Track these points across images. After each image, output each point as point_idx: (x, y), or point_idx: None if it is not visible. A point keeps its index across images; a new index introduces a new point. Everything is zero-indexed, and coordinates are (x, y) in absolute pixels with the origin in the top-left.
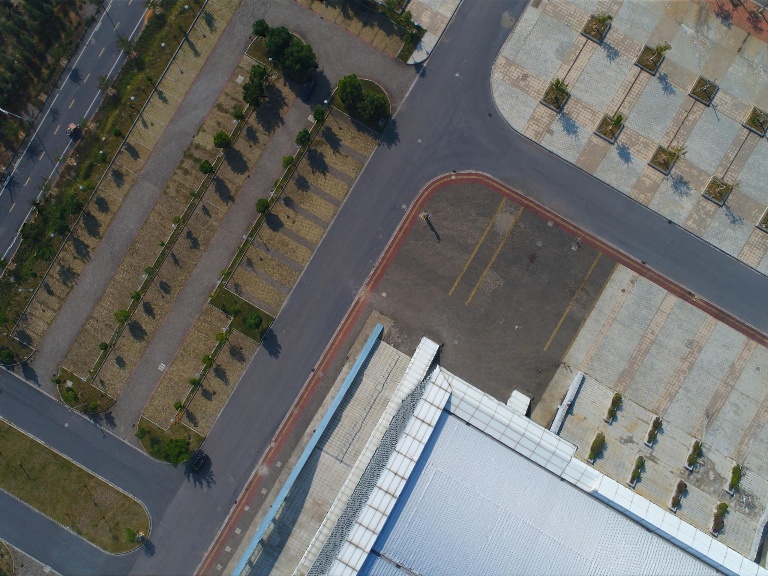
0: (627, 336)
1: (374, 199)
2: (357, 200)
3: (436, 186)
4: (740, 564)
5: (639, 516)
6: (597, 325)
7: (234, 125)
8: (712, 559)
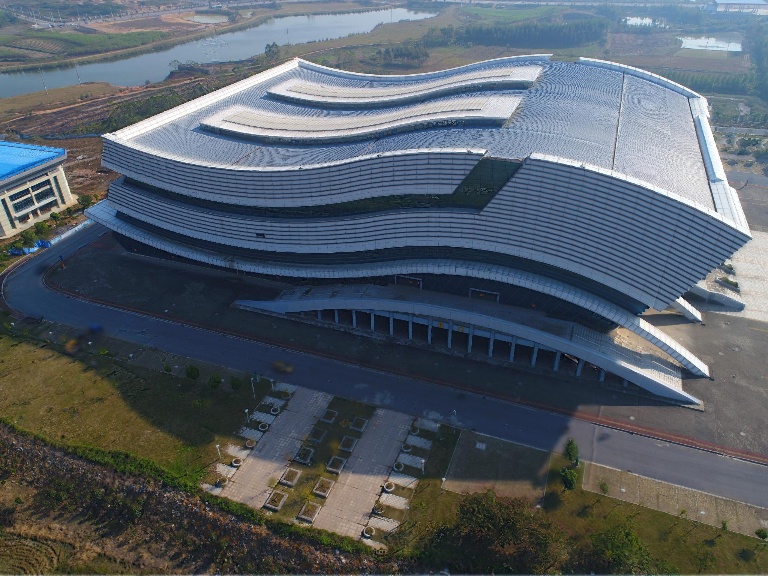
0: (766, 244)
1: (734, 175)
2: (728, 172)
3: (765, 187)
4: (711, 142)
5: (701, 122)
6: (759, 234)
7: (721, 147)
8: (704, 135)
